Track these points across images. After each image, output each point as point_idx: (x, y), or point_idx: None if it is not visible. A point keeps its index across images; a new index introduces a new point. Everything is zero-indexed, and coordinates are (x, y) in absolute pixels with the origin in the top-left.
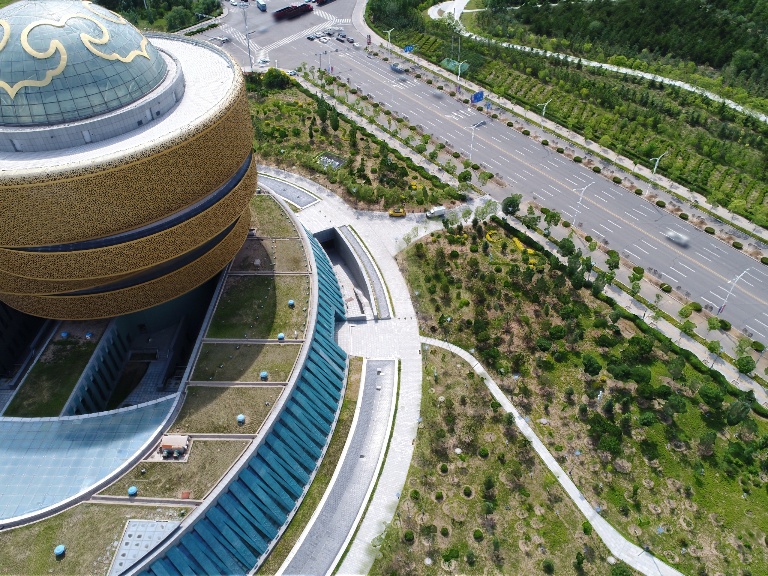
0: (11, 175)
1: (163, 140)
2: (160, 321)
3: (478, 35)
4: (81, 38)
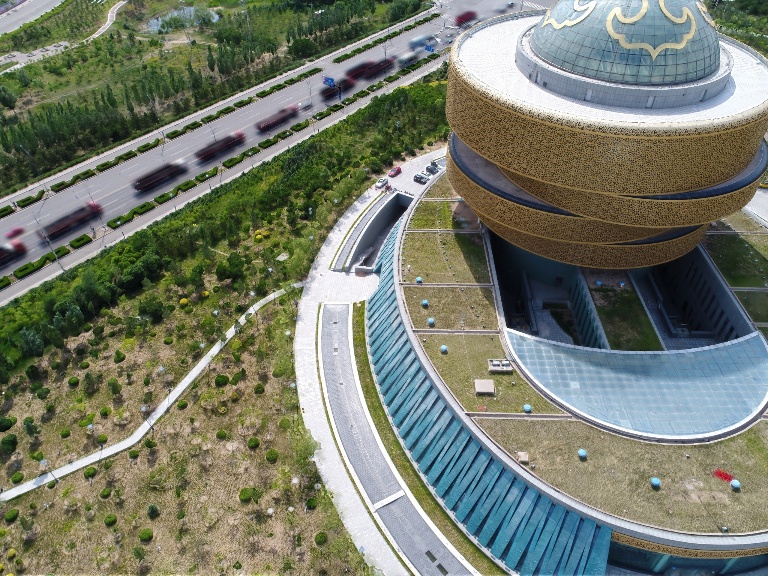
0: (686, 126)
1: None
2: (637, 276)
3: (721, 25)
4: (697, 6)
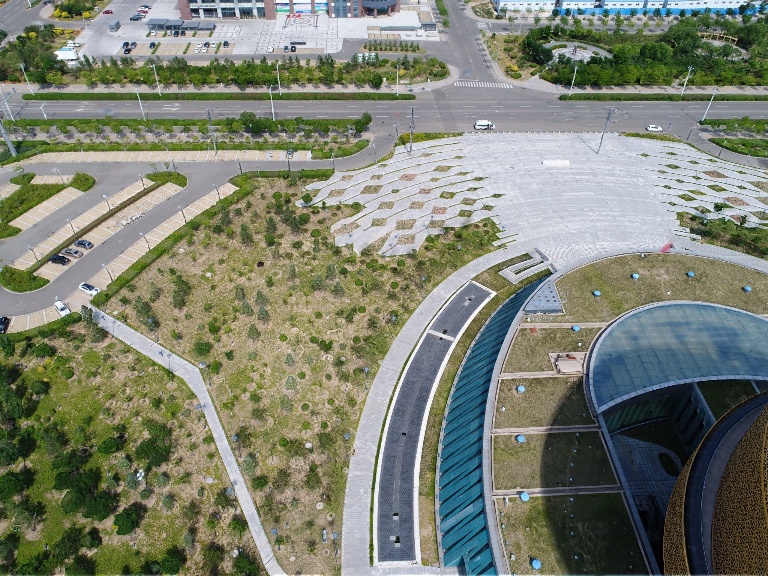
0: None
1: None
2: None
3: None
4: None
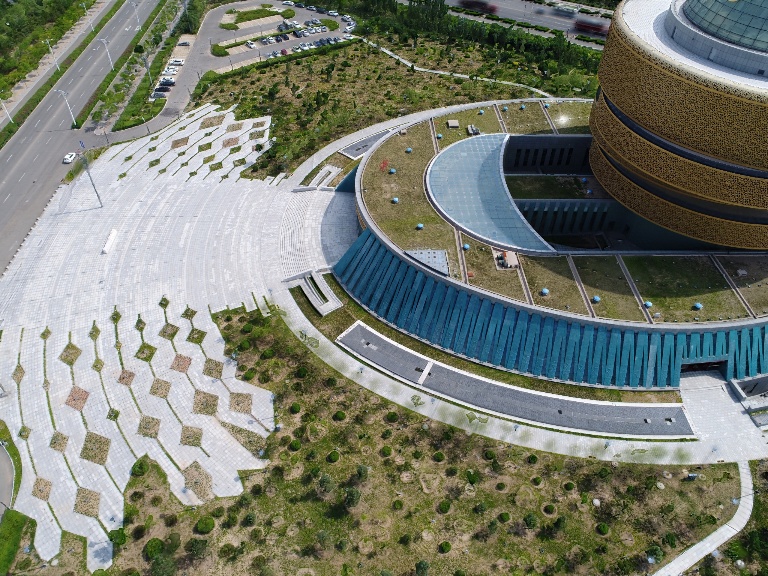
0: (637, 41)
1: (742, 87)
2: (639, 237)
3: None
4: None
